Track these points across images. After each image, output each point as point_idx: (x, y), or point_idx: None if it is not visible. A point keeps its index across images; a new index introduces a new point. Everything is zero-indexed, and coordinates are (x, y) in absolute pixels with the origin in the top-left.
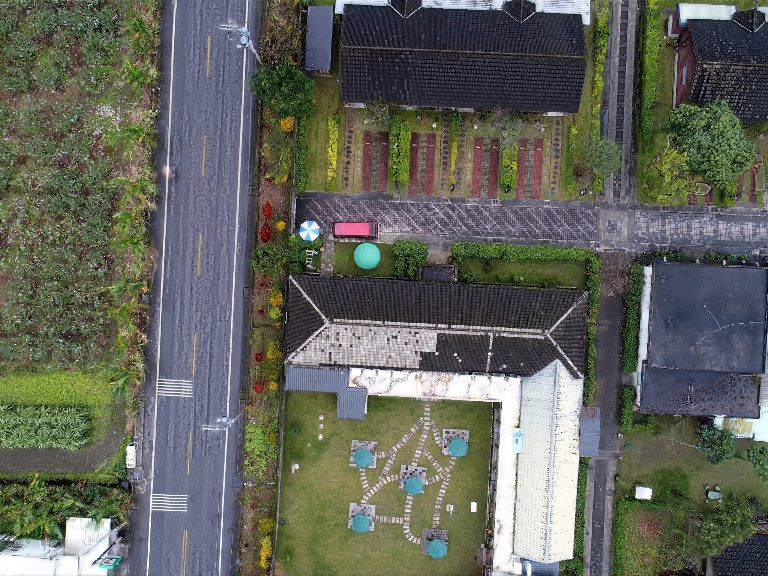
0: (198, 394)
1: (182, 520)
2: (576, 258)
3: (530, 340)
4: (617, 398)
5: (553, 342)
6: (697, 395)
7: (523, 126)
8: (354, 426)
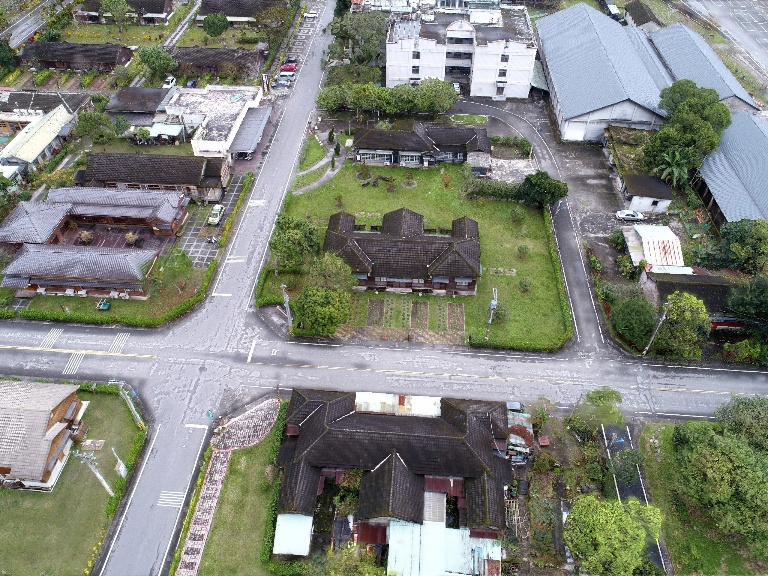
0: None
1: None
2: (98, 97)
3: (50, 96)
4: None
5: (60, 96)
6: None
7: (98, 73)
8: None
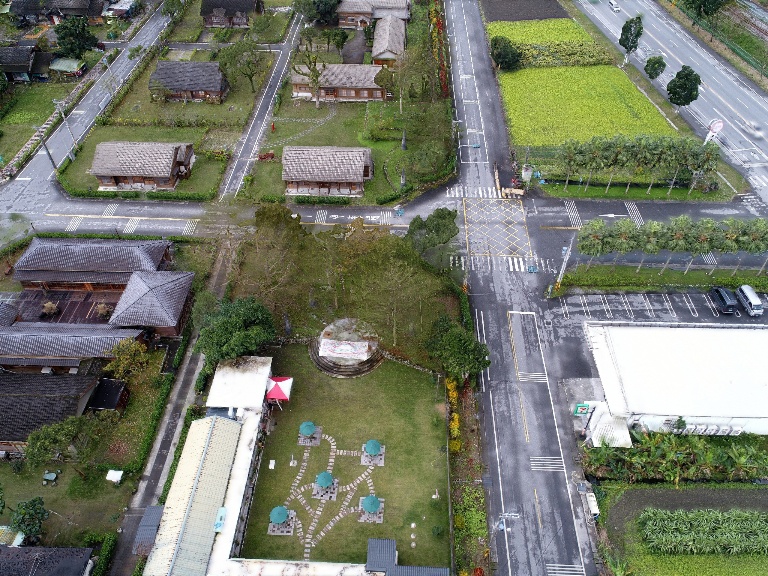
0: (541, 567)
1: (533, 450)
2: None
3: None
4: (111, 570)
5: None
6: (28, 568)
7: None
8: (381, 537)
